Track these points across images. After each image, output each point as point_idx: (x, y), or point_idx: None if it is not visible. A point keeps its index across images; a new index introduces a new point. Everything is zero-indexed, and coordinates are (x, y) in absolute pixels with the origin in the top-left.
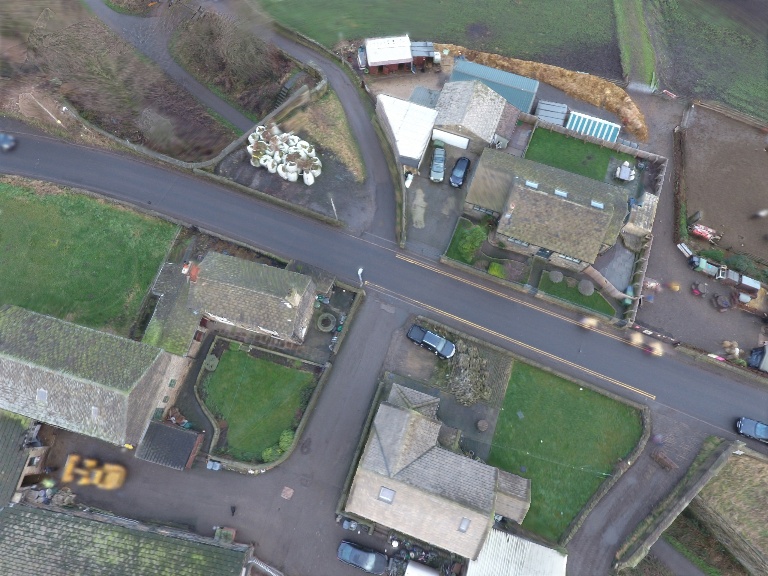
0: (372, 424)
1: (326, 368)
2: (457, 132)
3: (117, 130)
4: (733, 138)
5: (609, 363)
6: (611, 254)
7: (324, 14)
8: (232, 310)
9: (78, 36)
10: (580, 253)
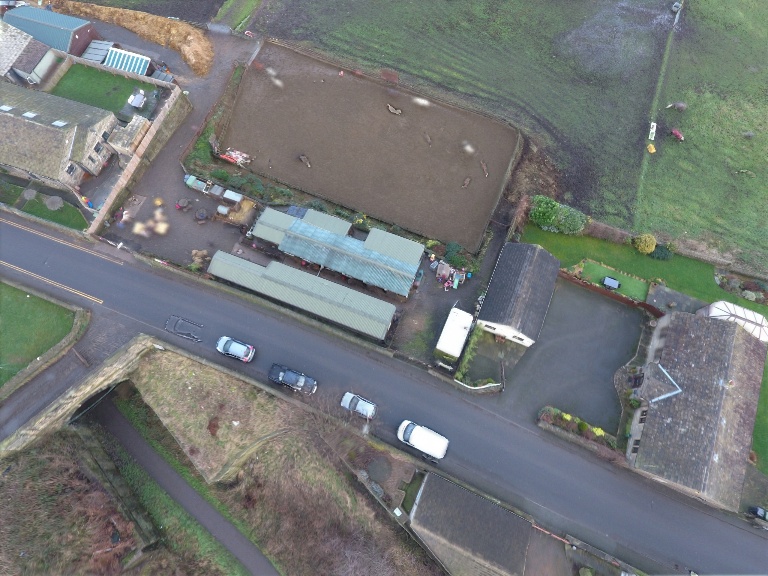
0: None
1: None
2: None
3: None
4: (295, 71)
5: (69, 273)
6: (106, 175)
7: None
8: None
9: None
10: (45, 170)
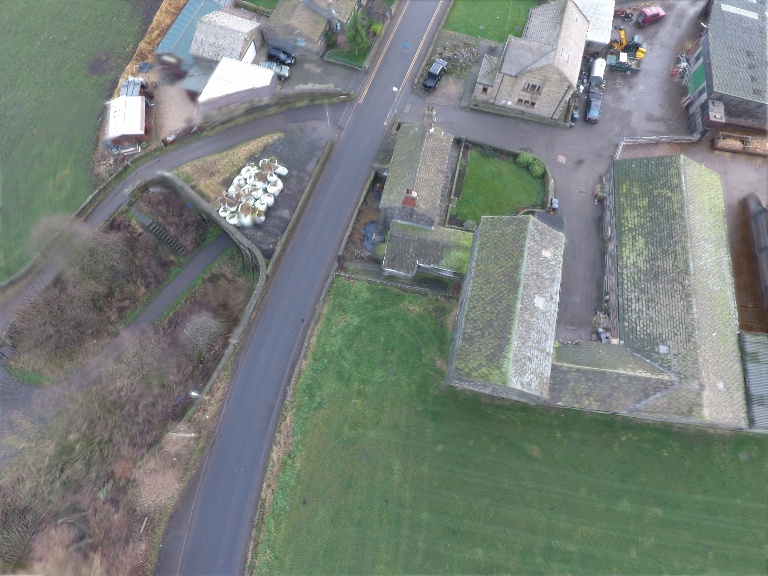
0: (504, 106)
1: (466, 138)
2: (247, 45)
3: (198, 386)
4: None
5: None
6: None
7: (40, 205)
8: (437, 179)
9: (5, 514)
10: None
